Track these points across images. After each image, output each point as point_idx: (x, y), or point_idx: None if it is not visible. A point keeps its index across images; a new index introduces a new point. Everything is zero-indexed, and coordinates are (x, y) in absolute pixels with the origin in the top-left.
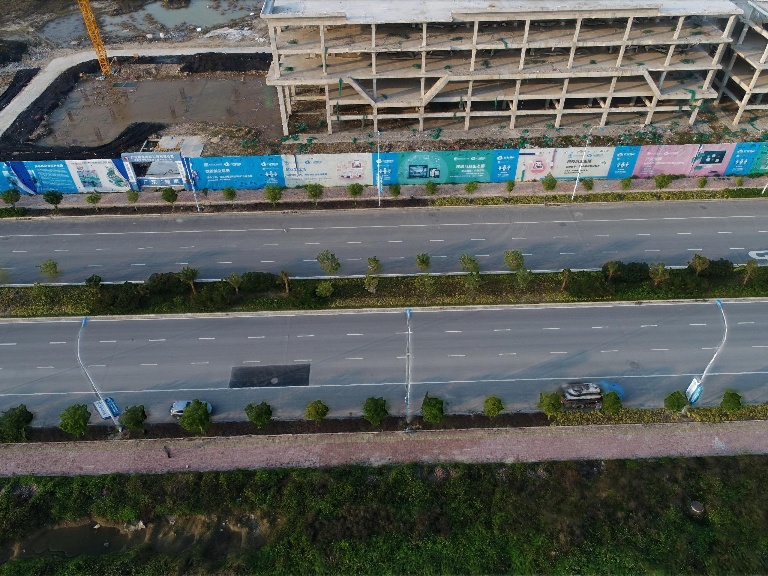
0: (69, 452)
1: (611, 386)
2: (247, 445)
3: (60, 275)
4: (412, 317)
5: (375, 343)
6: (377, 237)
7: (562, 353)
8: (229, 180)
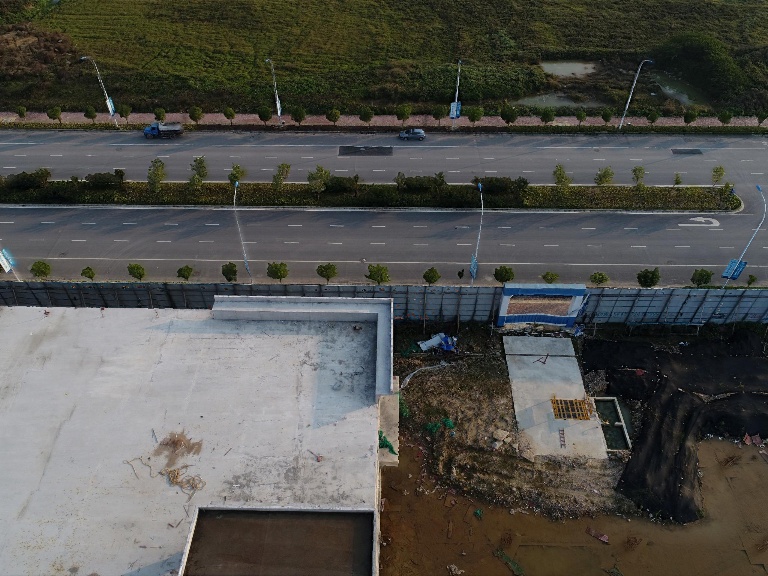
0: (477, 123)
1: (149, 129)
2: (375, 123)
3: (573, 220)
4: (257, 178)
5: (291, 165)
6: (266, 247)
7: (161, 156)
8: (442, 311)
